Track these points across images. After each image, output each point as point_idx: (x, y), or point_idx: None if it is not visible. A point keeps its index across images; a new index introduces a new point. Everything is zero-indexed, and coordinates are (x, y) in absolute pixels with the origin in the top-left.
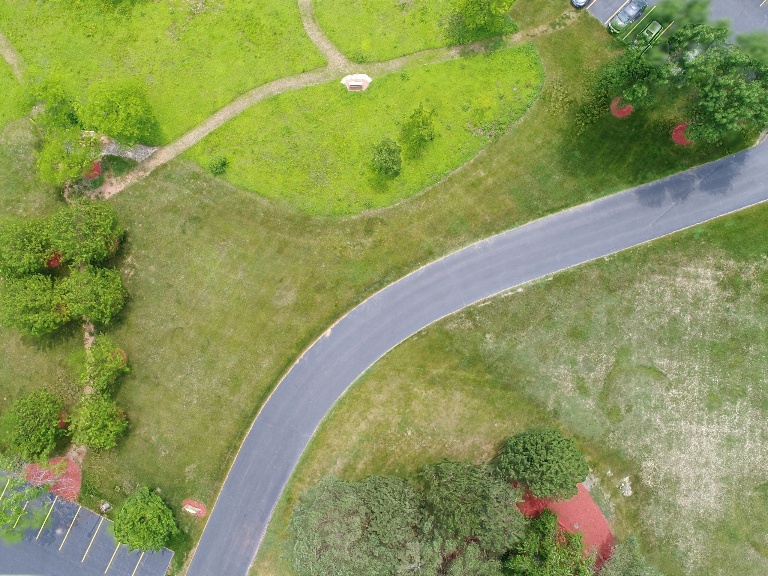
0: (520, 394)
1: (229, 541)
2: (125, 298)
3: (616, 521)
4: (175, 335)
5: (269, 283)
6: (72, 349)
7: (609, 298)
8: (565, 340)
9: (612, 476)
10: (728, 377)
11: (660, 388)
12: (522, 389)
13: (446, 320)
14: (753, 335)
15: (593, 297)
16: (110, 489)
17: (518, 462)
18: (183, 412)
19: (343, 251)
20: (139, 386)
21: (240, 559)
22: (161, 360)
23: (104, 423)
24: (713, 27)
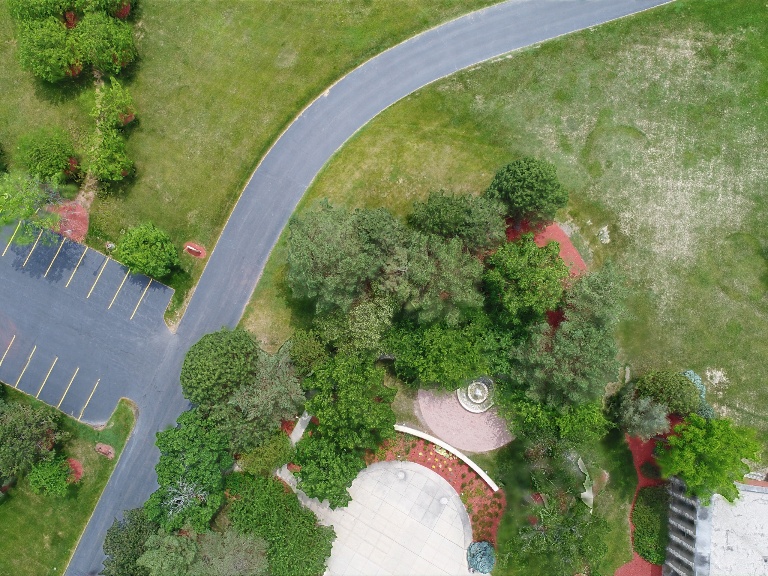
0: (507, 150)
1: (227, 281)
2: (135, 56)
3: (594, 265)
4: (181, 92)
5: (272, 47)
6: (83, 103)
7: (593, 64)
8: (550, 102)
9: (591, 225)
10: (703, 137)
11: (639, 146)
12: (509, 145)
13: (438, 83)
14: (728, 99)
15: (578, 63)
16: (116, 232)
17: (502, 180)
18: (187, 162)
19: (343, 19)
20: (146, 138)
21: (237, 297)
22: (167, 115)
23: (112, 156)
24: None
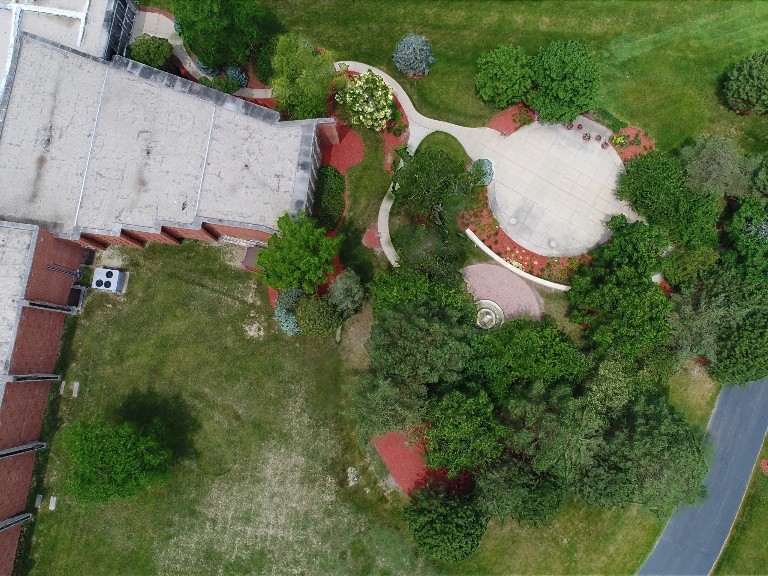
0: (451, 575)
1: (736, 435)
2: None
3: None
4: None
5: None
6: None
7: None
8: None
9: (365, 488)
10: None
11: (310, 575)
12: None
13: None
14: None
15: None
16: None
17: None
18: None
19: None
20: None
21: (724, 418)
22: None
23: None
24: None
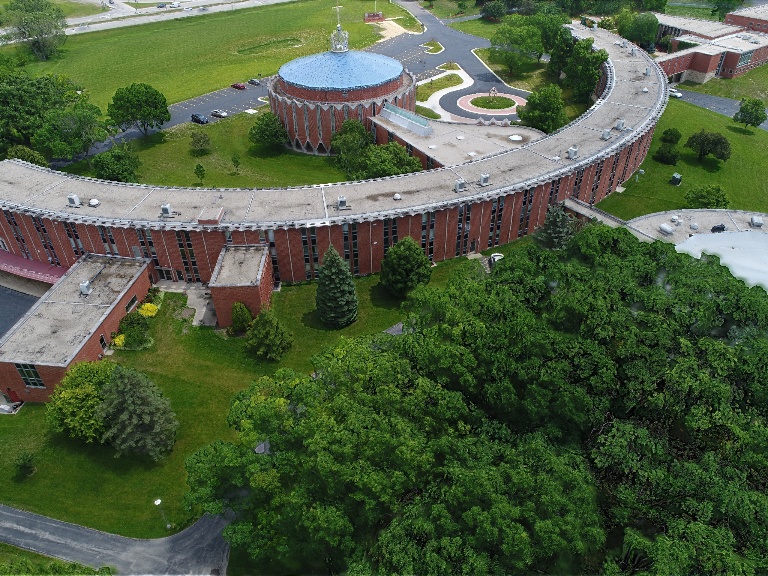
0: None
1: None
2: None
3: None
4: None
5: None
6: None
7: None
8: None
9: None
10: None
11: None
12: None
13: None
14: None
15: (681, 7)
16: None
17: None
18: None
19: None
20: None
21: None
22: None
23: None
24: (750, 2)
